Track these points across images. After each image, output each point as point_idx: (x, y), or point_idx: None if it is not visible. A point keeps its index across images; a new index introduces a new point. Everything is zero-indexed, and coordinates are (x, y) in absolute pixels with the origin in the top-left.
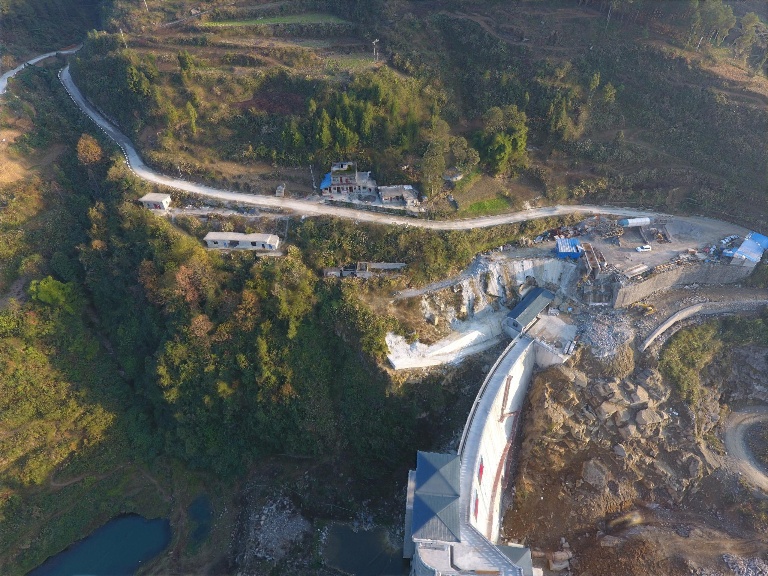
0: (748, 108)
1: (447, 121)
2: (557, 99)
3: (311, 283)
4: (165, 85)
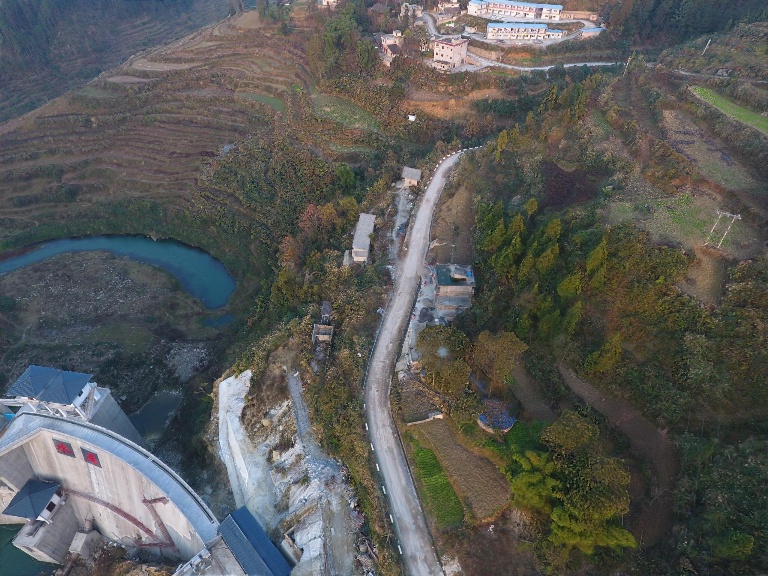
0: None
1: (634, 393)
2: None
3: (313, 295)
4: (559, 116)
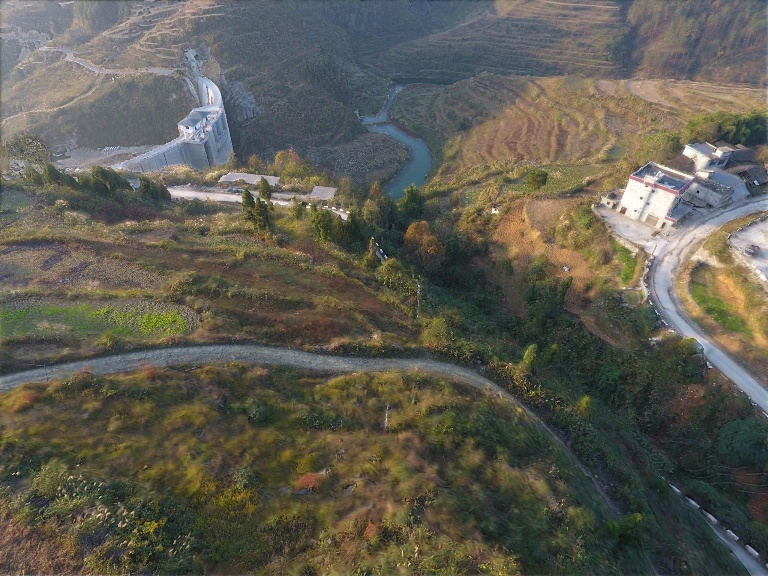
0: None
1: None
2: None
3: None
4: None
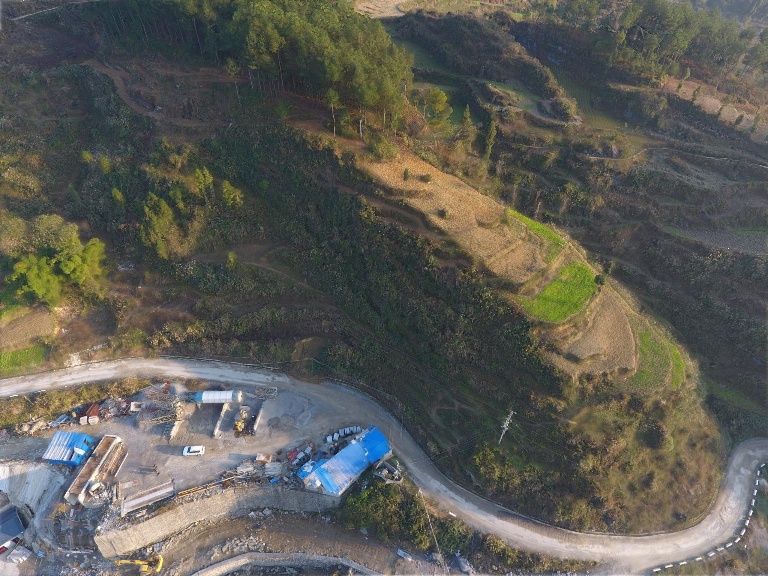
0: (398, 232)
1: None
2: (151, 201)
3: None
4: None
